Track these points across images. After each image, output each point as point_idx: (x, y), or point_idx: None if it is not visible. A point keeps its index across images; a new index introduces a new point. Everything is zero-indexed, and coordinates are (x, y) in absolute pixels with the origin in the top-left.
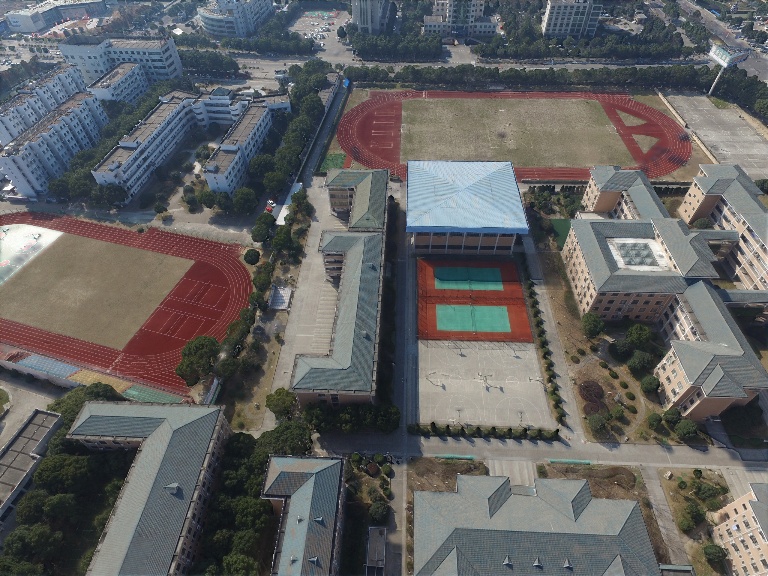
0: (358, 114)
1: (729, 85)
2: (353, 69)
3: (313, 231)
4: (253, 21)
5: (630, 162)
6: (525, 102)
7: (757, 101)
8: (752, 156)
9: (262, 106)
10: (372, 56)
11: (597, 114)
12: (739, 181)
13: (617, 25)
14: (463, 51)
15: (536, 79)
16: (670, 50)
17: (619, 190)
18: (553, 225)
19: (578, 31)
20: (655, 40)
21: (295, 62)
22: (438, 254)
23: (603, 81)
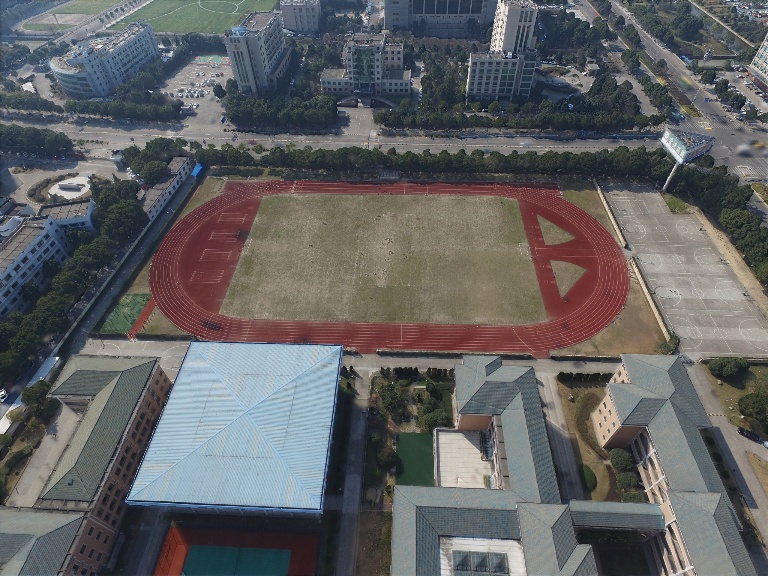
0: (196, 221)
1: (688, 182)
2: (206, 152)
3: (38, 456)
4: (120, 73)
5: (539, 314)
6: (421, 201)
7: (723, 211)
8: (711, 304)
9: (39, 227)
10: (250, 124)
11: (510, 223)
12: (674, 403)
13: (564, 77)
14: (365, 117)
15: (439, 167)
16: (619, 121)
17: (488, 414)
18: (395, 454)
19: (509, 91)
20: (602, 106)
21: (152, 133)
22: (206, 514)
23: (526, 170)
